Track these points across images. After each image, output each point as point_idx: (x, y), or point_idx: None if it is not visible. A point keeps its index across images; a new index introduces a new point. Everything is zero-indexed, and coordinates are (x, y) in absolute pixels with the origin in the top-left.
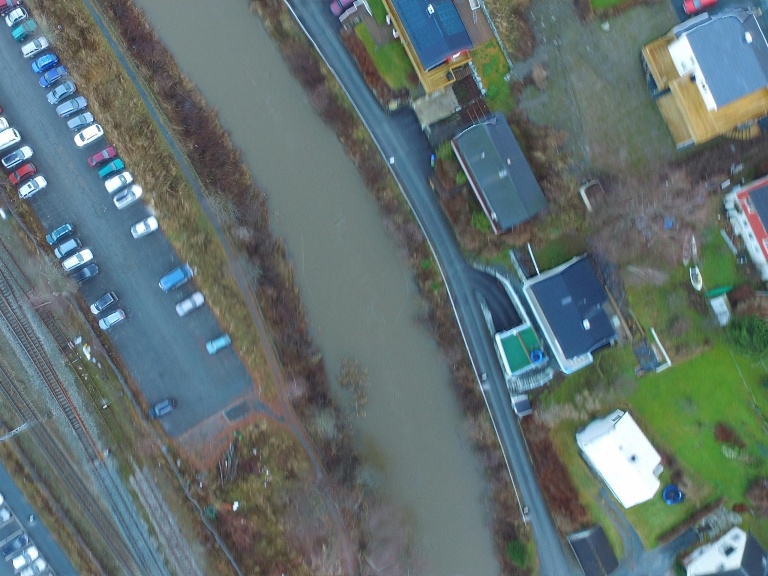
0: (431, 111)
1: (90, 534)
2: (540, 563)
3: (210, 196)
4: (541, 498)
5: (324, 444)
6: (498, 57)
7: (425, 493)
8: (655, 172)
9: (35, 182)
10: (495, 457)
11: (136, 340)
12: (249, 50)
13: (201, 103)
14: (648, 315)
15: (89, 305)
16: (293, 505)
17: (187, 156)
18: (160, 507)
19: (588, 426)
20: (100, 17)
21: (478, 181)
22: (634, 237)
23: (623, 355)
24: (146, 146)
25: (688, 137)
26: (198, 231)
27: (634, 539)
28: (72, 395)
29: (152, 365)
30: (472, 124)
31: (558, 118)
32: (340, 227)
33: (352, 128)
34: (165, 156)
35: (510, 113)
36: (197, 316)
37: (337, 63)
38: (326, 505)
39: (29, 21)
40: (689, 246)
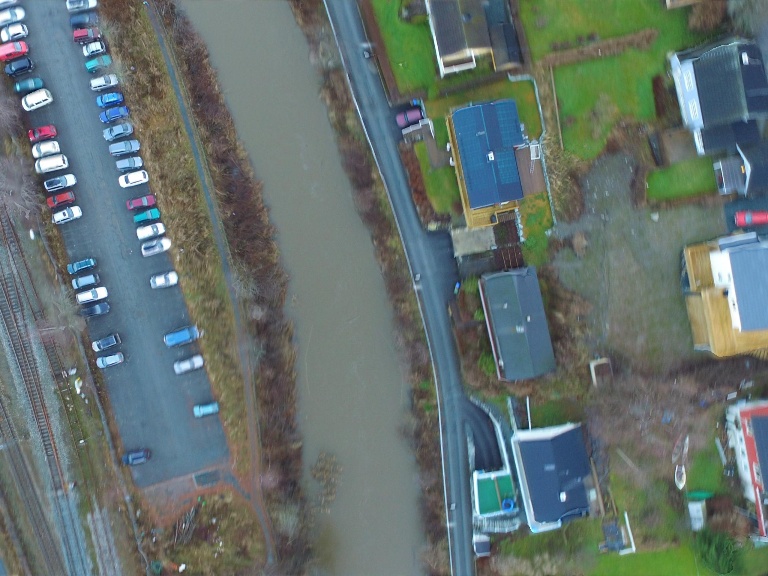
0: (467, 243)
1: (36, 559)
2: None
3: (235, 266)
4: None
5: (282, 531)
6: (545, 210)
7: None
8: (667, 366)
9: (71, 211)
10: None
11: (128, 385)
12: (308, 133)
13: (249, 174)
14: (625, 498)
15: (92, 341)
16: None
17: (222, 222)
18: (109, 550)
19: None
20: (174, 68)
21: (495, 327)
22: (631, 422)
23: (591, 528)
24: (186, 202)
25: (707, 342)
26: (214, 296)
27: None
28: (53, 422)
29: (137, 413)
30: (503, 266)
31: (587, 288)
32: (352, 325)
33: (387, 235)
34: (201, 216)
35: (542, 267)
36: (192, 377)
37: (389, 171)
38: None
39: (105, 55)
40: (681, 444)
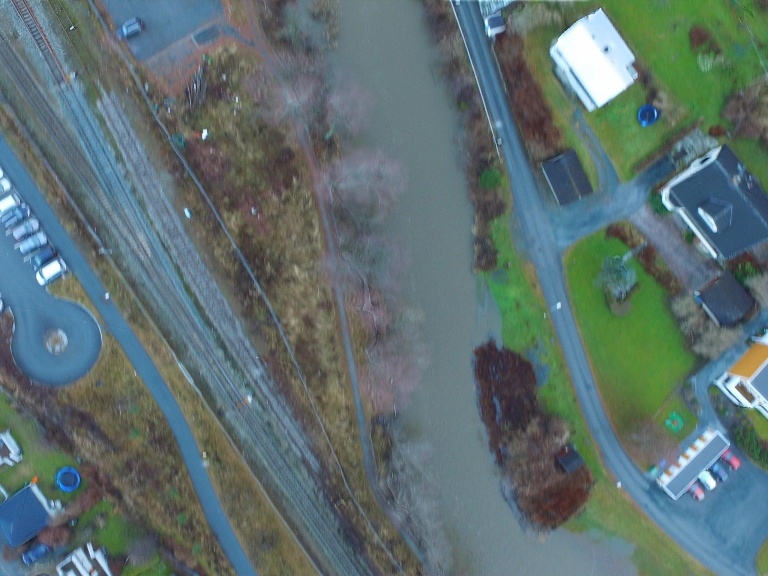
0: None
1: (56, 159)
2: (514, 198)
3: None
4: (515, 131)
5: (295, 71)
6: None
7: (397, 124)
8: None
9: None
10: (468, 81)
11: None
12: None
13: None
14: None
15: None
16: (263, 134)
17: None
18: (128, 133)
19: None
20: None
21: None
22: None
23: None
24: None
25: None
26: None
27: (609, 170)
28: (38, 15)
29: None
30: None
31: None
32: None
33: None
34: None
35: None
36: None
37: None
38: (296, 133)
39: None
40: None
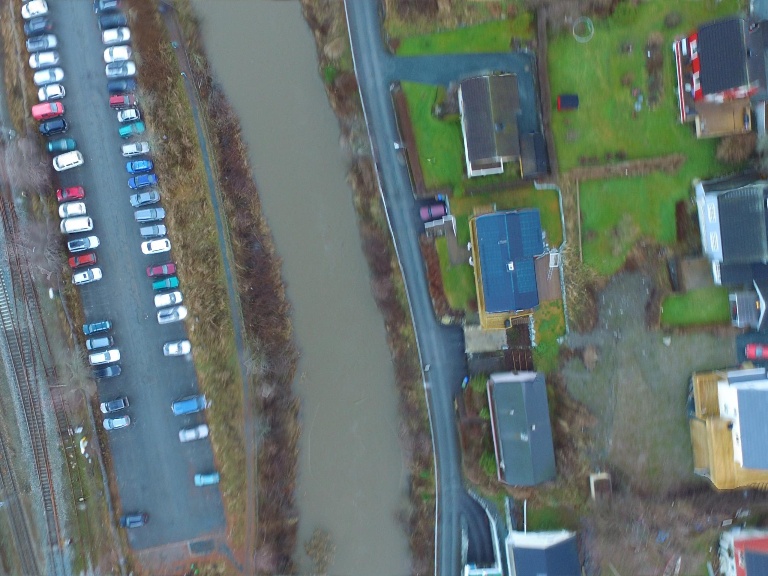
0: (479, 340)
1: None
2: None
3: (248, 340)
4: None
5: None
6: (558, 318)
7: None
8: (666, 487)
9: (91, 273)
10: None
11: (132, 448)
12: (332, 214)
13: (270, 250)
14: None
15: (100, 401)
16: None
17: (240, 296)
18: None
19: None
20: (205, 140)
21: (499, 431)
22: None
23: None
24: (205, 274)
25: (707, 468)
26: (225, 368)
27: None
28: (55, 478)
29: (139, 476)
30: (513, 367)
31: (594, 401)
32: (358, 407)
33: (401, 323)
34: (219, 288)
35: (551, 373)
36: (196, 445)
37: (408, 261)
38: None
39: (139, 123)
40: (673, 564)
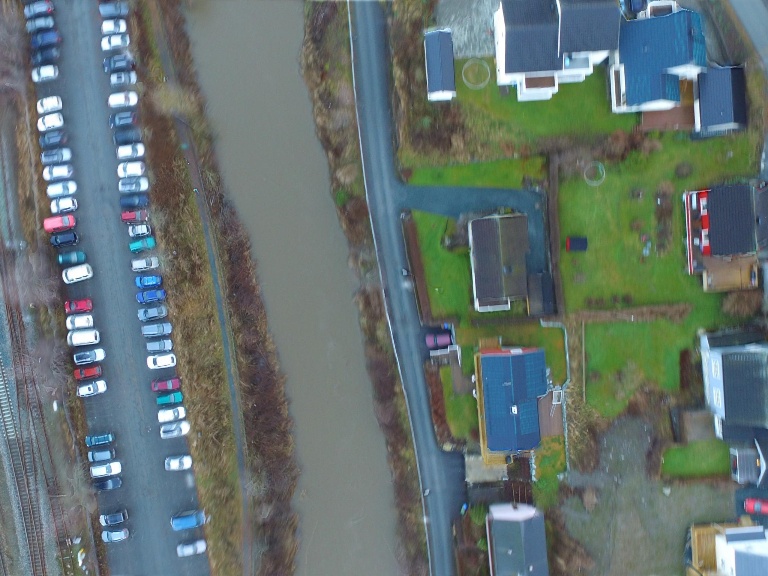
0: (480, 470)
1: None
2: None
3: (249, 456)
4: None
5: None
6: (559, 454)
7: None
8: None
9: (96, 385)
10: None
11: (129, 560)
12: (338, 333)
13: (275, 367)
14: None
15: (100, 513)
16: None
17: (243, 413)
18: None
19: None
20: (215, 257)
21: (496, 567)
22: None
23: None
24: (209, 389)
25: None
26: (225, 484)
27: None
28: None
29: None
30: (512, 499)
31: (592, 543)
32: (356, 525)
33: (402, 446)
34: (223, 404)
35: (550, 509)
36: (194, 560)
37: (412, 386)
38: None
39: (149, 238)
40: None
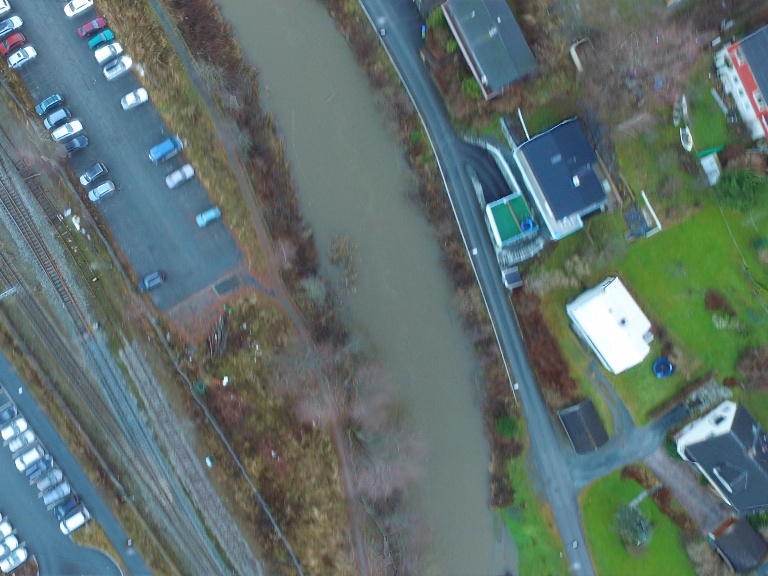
0: None
1: (79, 408)
2: (530, 440)
3: (200, 68)
4: (531, 375)
5: (314, 319)
6: None
7: (415, 369)
8: (645, 30)
9: (25, 52)
10: (485, 331)
11: (126, 213)
12: None
13: None
14: (638, 178)
15: (79, 177)
16: (283, 380)
17: (177, 27)
18: (149, 381)
19: (578, 297)
20: None
21: (468, 43)
22: (624, 97)
23: (613, 221)
24: (136, 17)
25: None
26: (188, 103)
27: (624, 415)
28: (61, 268)
29: (142, 238)
30: None
31: None
32: (331, 103)
33: (343, 1)
34: (155, 28)
35: None
36: (187, 189)
37: None
38: (316, 380)
39: None
40: (679, 106)
